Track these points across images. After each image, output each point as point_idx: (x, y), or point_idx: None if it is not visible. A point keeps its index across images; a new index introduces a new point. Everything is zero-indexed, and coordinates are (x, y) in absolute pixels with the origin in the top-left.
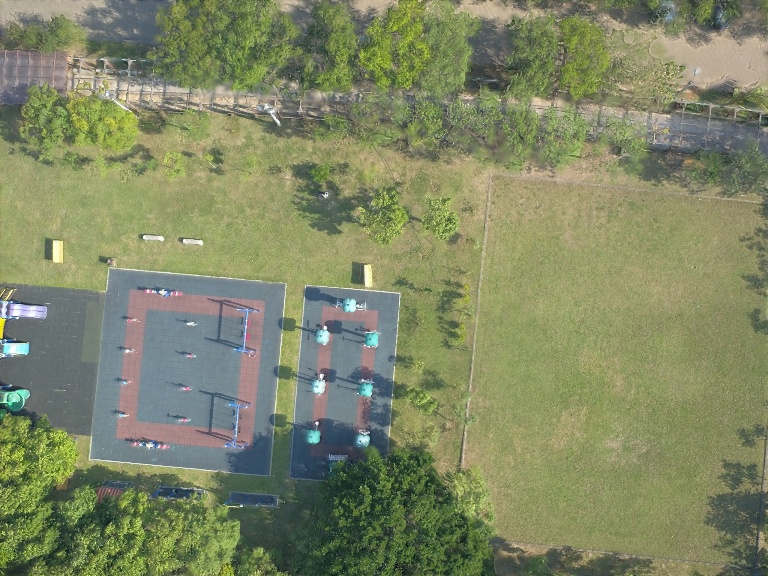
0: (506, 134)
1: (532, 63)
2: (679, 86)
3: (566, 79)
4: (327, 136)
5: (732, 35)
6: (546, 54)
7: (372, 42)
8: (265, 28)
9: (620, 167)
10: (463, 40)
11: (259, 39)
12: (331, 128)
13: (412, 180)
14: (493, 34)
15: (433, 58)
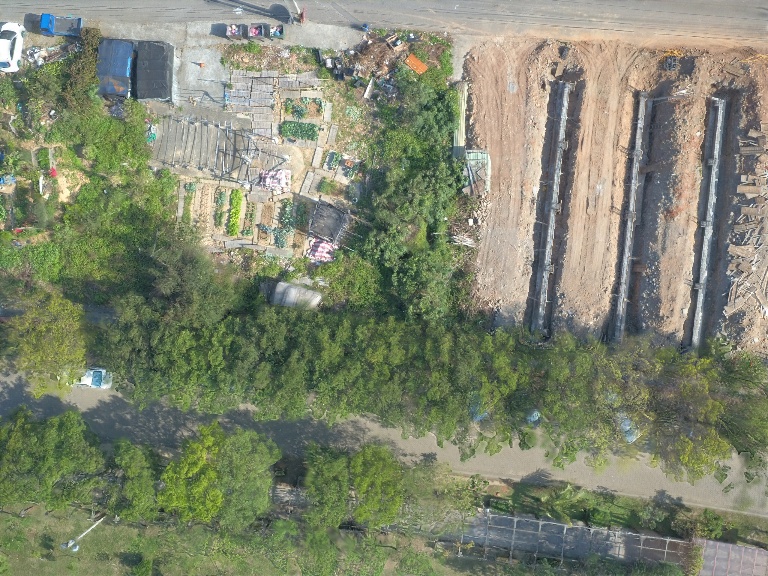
0: (302, 571)
1: (325, 505)
2: (494, 479)
3: (357, 522)
4: (151, 526)
5: (546, 430)
6: (337, 498)
7: (167, 488)
8: (68, 467)
9: (436, 558)
10: (262, 473)
11: (67, 469)
12: (154, 521)
13: (234, 568)
14: (311, 427)
15: (228, 501)
